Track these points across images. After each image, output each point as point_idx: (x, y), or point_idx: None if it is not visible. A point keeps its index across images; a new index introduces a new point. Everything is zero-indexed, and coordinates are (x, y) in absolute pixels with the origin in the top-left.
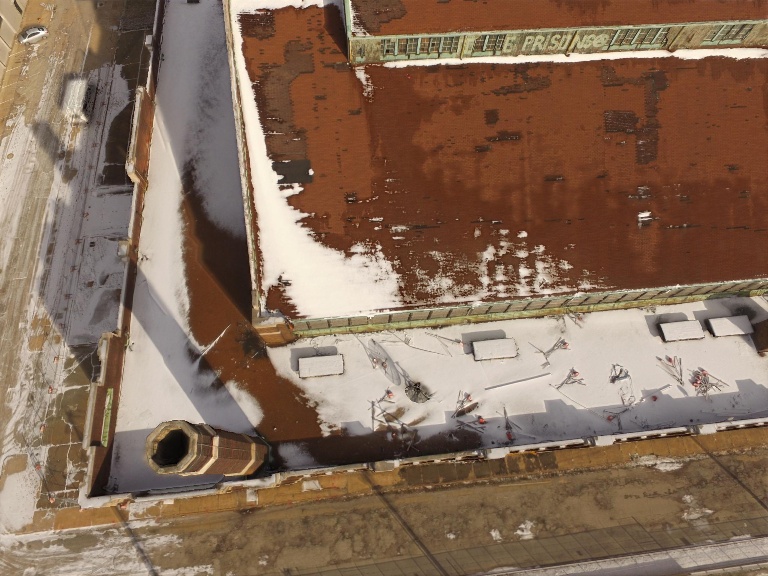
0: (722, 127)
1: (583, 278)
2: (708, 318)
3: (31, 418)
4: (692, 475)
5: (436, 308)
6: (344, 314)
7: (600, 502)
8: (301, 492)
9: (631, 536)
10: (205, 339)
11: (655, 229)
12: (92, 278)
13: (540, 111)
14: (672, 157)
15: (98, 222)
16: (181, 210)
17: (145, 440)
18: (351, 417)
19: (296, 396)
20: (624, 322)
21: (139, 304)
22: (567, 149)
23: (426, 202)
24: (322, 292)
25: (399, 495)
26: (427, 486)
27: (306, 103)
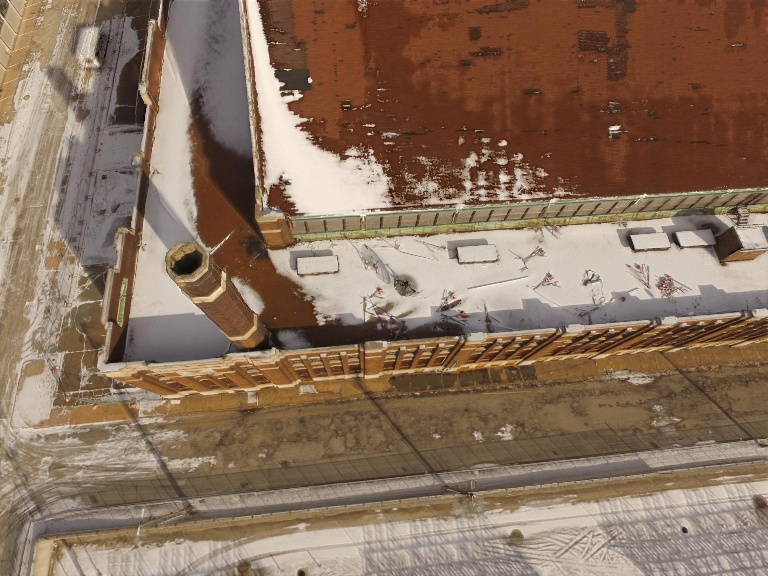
0: (687, 48)
1: (558, 185)
2: (675, 232)
3: (48, 328)
4: (662, 388)
5: (423, 209)
6: (339, 212)
7: (576, 410)
8: (298, 395)
9: (604, 439)
10: (211, 242)
11: (624, 141)
12: (104, 207)
13: (519, 29)
14: (640, 75)
15: (110, 157)
16: (190, 131)
17: (156, 325)
18: (344, 310)
19: (294, 291)
20: (597, 234)
21: (151, 211)
22: (544, 65)
23: (415, 111)
24: (319, 192)
25: (389, 400)
26: (415, 393)
27: (306, 16)
